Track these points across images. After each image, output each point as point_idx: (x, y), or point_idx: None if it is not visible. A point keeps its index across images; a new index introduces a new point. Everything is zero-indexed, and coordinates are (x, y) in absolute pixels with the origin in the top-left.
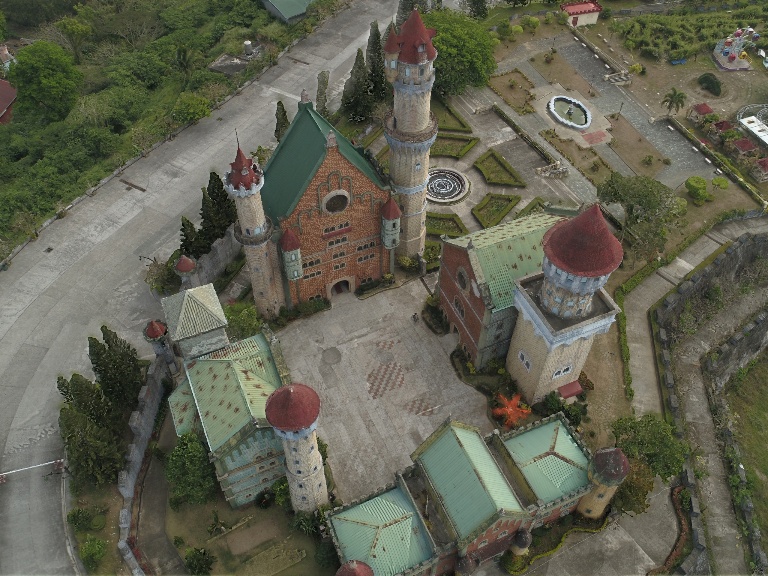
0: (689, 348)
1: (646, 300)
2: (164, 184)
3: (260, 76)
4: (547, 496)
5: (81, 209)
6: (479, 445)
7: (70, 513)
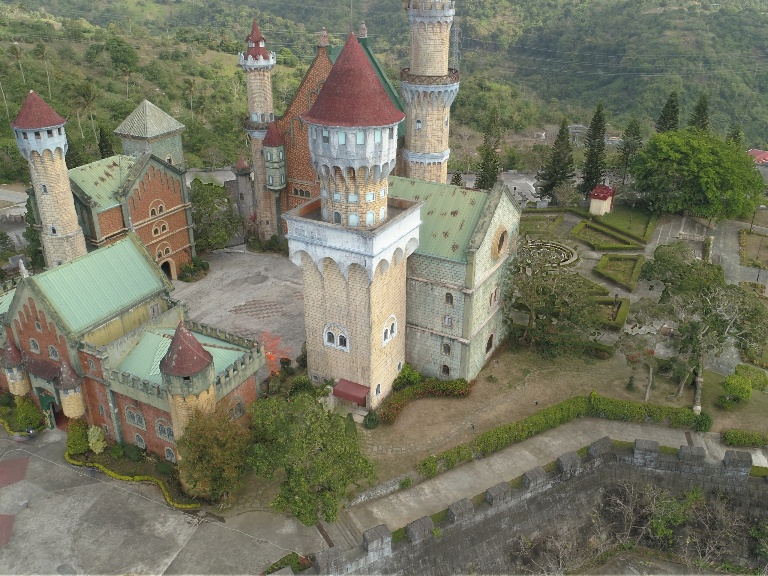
0: (660, 570)
1: (621, 438)
2: None
3: (532, 174)
4: (133, 373)
5: None
6: (143, 284)
7: (0, 230)
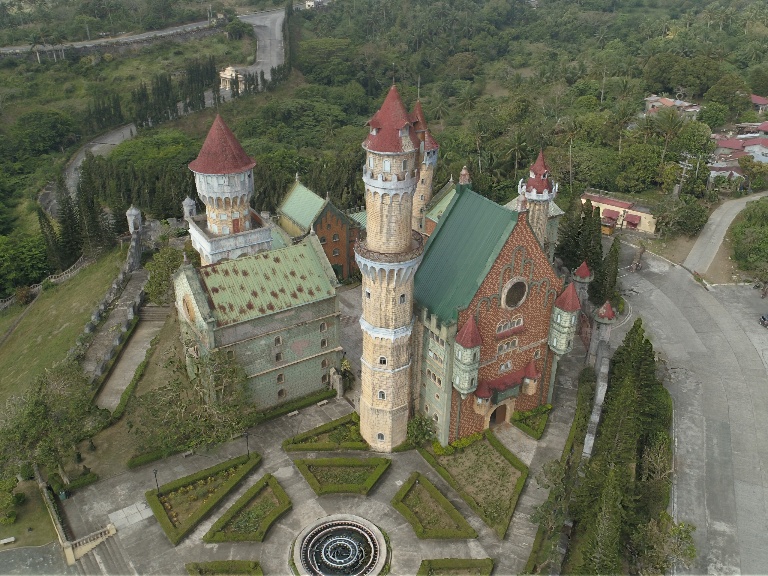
0: None
1: None
2: None
3: None
4: None
5: None
6: None
7: None
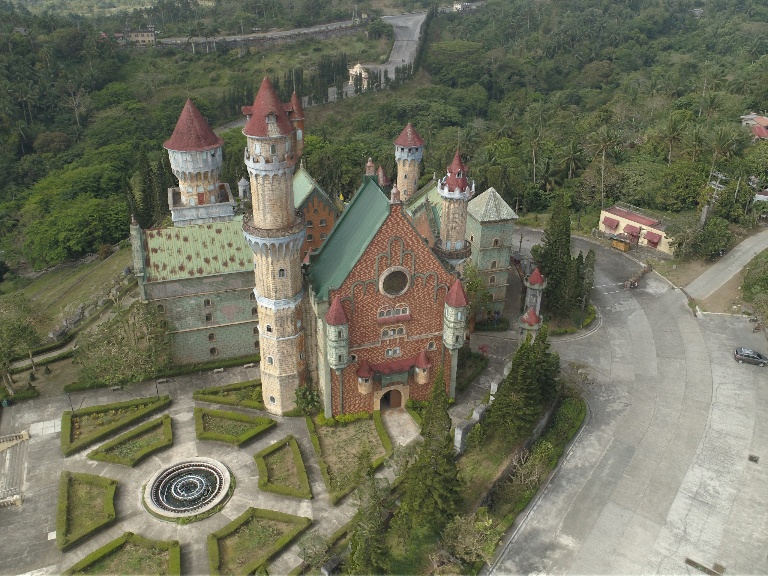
0: None
1: None
2: (662, 574)
3: None
4: None
5: (767, 527)
6: None
7: None
